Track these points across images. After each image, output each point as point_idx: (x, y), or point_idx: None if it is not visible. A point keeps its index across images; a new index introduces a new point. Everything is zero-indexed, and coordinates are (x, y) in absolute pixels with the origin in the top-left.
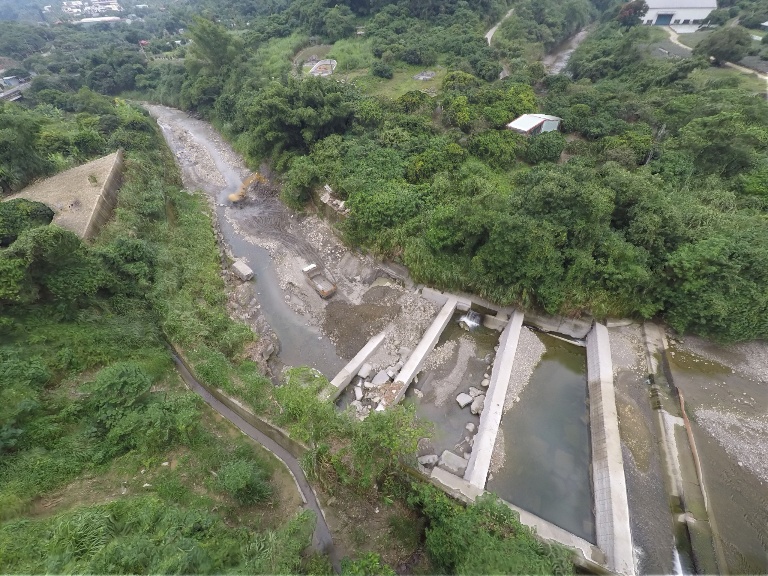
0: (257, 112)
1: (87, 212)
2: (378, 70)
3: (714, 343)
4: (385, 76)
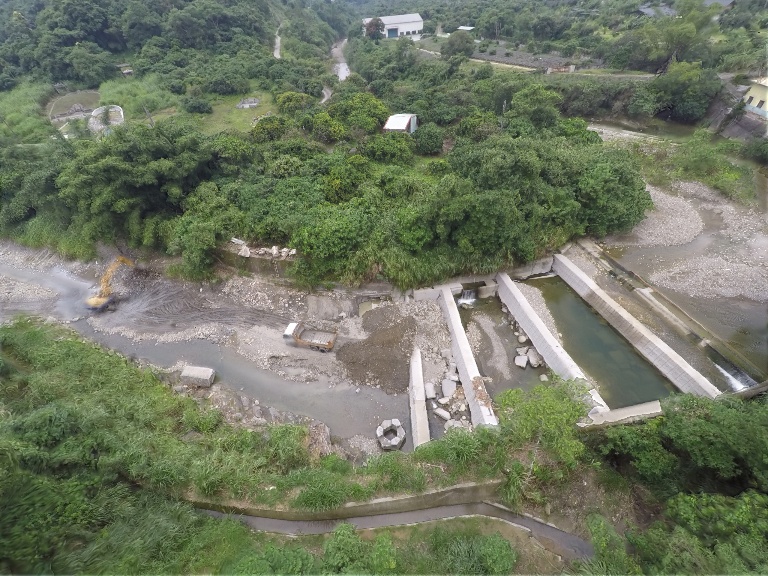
0: (83, 182)
1: None
2: (194, 106)
3: (619, 235)
4: (205, 111)
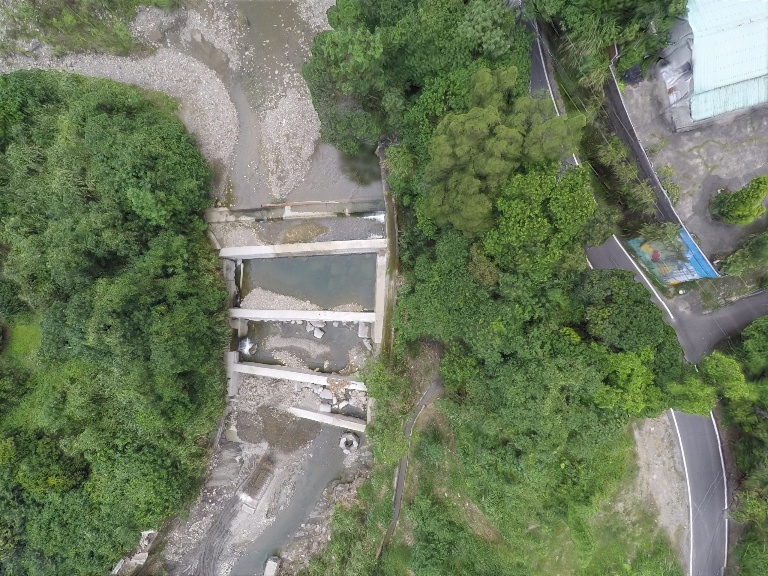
0: None
1: None
2: None
3: None
4: None
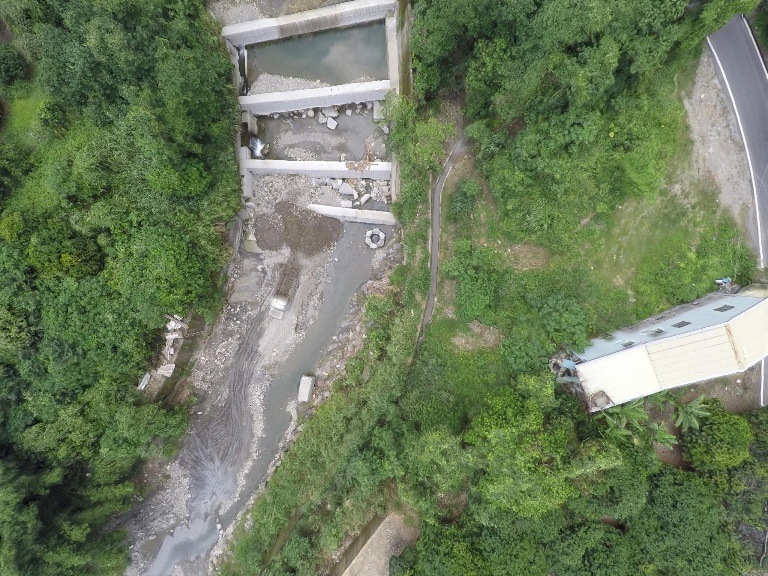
0: None
1: (356, 569)
2: None
3: None
4: None
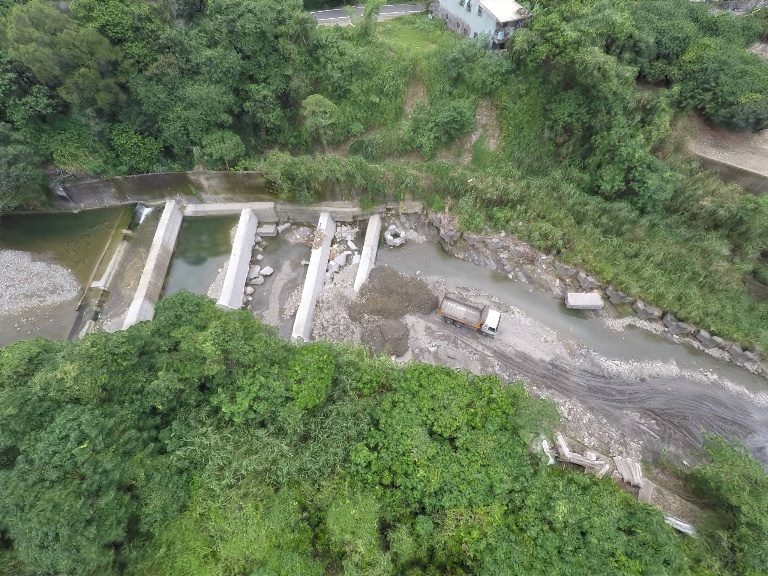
0: None
1: None
2: None
3: None
4: None
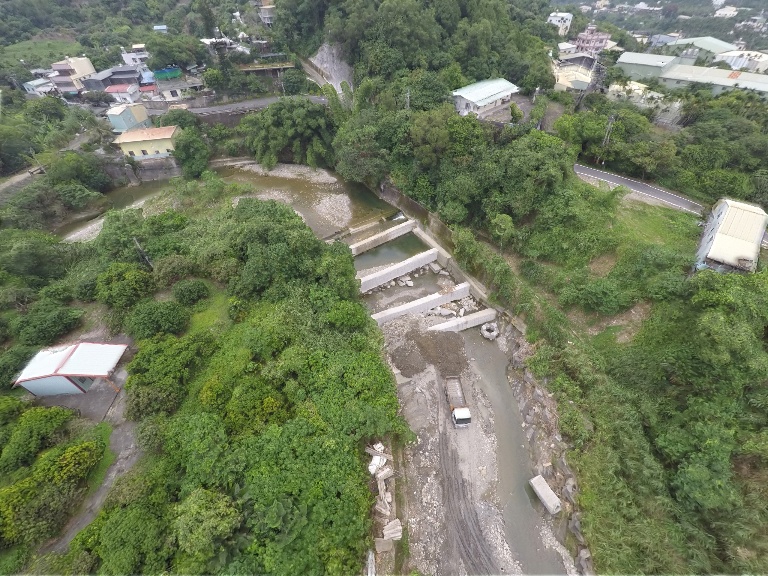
0: None
1: None
2: None
3: None
4: None
